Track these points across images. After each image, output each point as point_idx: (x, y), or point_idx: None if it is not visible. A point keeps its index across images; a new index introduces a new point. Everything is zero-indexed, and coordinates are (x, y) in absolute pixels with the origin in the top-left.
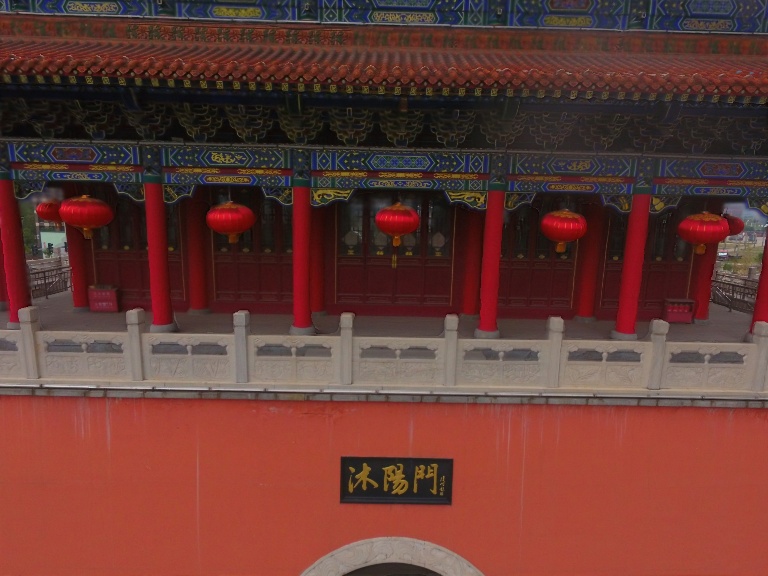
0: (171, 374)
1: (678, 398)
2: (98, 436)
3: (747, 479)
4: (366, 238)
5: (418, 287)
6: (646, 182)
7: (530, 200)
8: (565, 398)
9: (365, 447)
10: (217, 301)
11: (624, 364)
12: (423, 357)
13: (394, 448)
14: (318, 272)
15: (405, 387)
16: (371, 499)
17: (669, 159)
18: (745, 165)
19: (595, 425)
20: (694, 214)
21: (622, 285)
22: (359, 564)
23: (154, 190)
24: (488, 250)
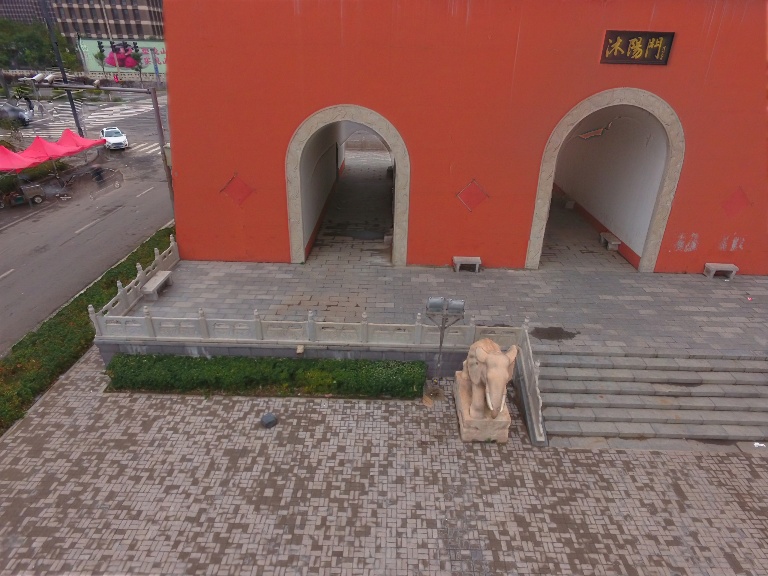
0: None
1: None
2: (461, 14)
3: None
4: None
5: None
6: None
7: None
8: None
9: (622, 24)
10: None
11: None
12: None
13: (639, 25)
14: None
15: None
16: (619, 61)
17: None
18: None
19: None
20: None
21: None
22: (603, 105)
23: None
24: None
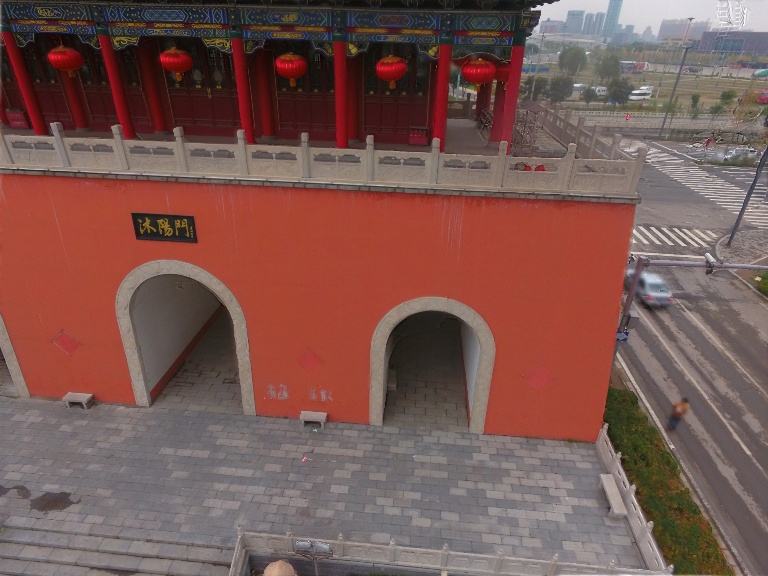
0: (28, 161)
1: (317, 183)
2: None
3: (365, 235)
4: (186, 74)
5: (230, 114)
6: (338, 31)
7: (262, 45)
8: (250, 181)
9: (143, 208)
10: (94, 122)
11: (287, 161)
12: (167, 154)
13: (160, 209)
14: (156, 101)
15: (157, 172)
16: (153, 238)
17: (354, 12)
18: (411, 17)
19: (271, 199)
20: (385, 57)
21: (336, 112)
22: (154, 274)
23: (8, 37)
24: (237, 84)
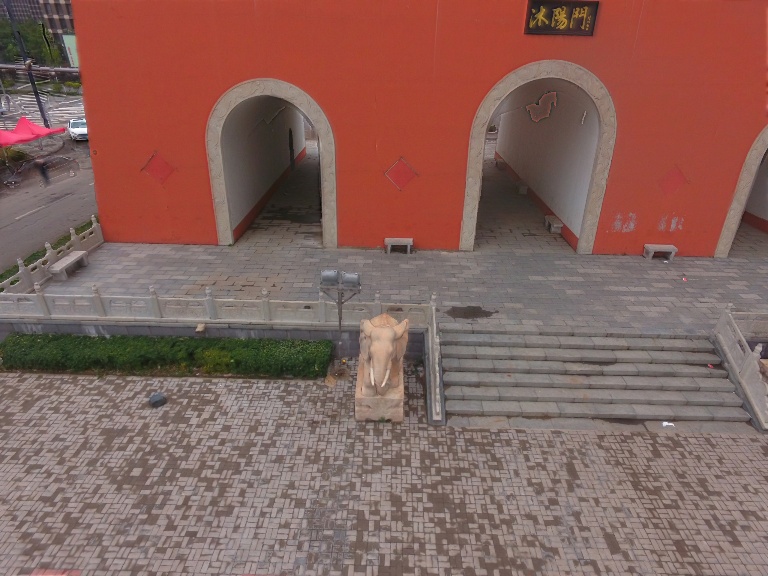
0: None
1: None
2: None
3: None
4: None
5: None
6: None
7: None
8: None
9: None
10: None
11: None
12: None
13: None
14: None
15: None
16: (543, 32)
17: None
18: None
19: None
20: None
21: None
22: (530, 79)
23: None
24: None
